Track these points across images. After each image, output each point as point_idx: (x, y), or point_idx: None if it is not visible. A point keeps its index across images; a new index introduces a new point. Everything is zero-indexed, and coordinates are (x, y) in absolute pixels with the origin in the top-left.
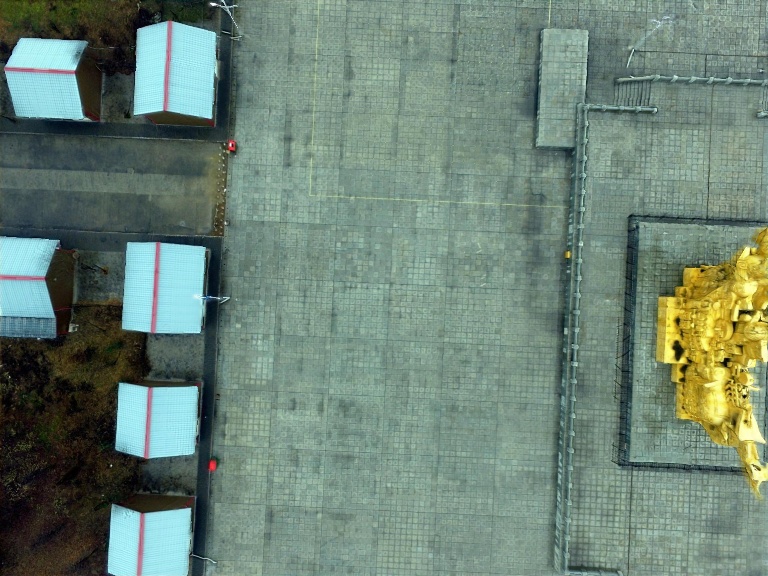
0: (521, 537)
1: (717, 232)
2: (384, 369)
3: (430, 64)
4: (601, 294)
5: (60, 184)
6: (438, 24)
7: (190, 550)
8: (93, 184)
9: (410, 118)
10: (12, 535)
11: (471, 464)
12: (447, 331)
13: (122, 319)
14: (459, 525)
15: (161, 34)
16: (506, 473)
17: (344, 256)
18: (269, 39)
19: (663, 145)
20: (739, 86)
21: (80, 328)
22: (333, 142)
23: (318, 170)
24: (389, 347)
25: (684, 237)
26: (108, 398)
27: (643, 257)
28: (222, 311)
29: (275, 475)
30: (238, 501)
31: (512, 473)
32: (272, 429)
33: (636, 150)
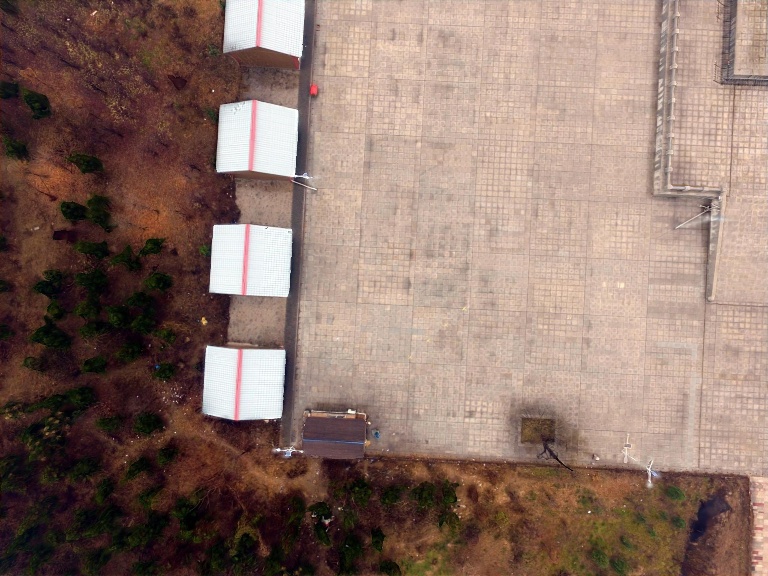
0: (620, 165)
1: None
2: None
3: None
4: None
5: None
6: None
7: None
8: None
9: None
10: (116, 156)
11: (570, 93)
12: None
13: None
14: (558, 154)
15: None
16: (605, 102)
17: None
18: None
19: None
20: None
21: None
22: None
23: None
24: None
25: None
26: (210, 24)
27: None
28: None
29: (374, 105)
30: (338, 130)
31: (611, 102)
32: (372, 59)
33: None
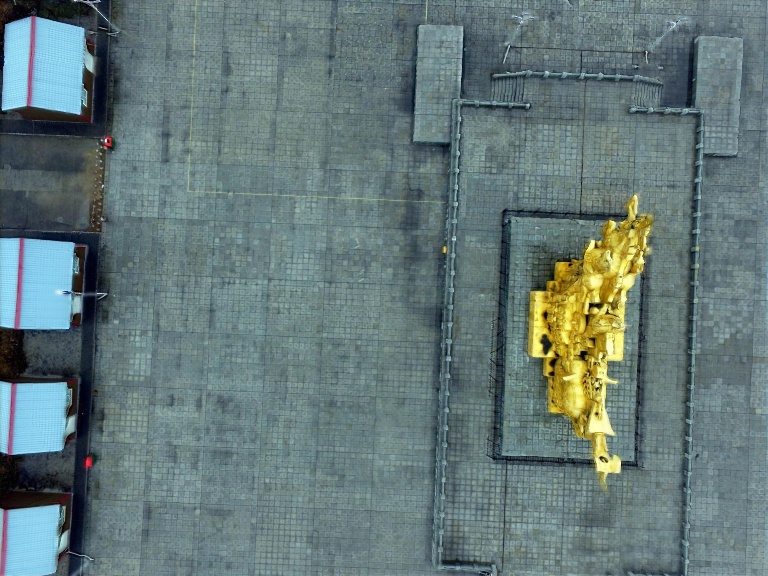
0: (399, 532)
1: (588, 226)
2: (262, 365)
3: (308, 60)
4: (476, 289)
5: None
6: (316, 20)
7: (65, 547)
8: None
9: (288, 114)
10: None
11: (349, 459)
12: (325, 326)
13: None
14: (337, 520)
15: (25, 29)
16: (384, 468)
17: (222, 252)
18: (147, 35)
19: (537, 140)
20: (611, 82)
21: None
22: (211, 138)
23: (196, 166)
24: (267, 343)
25: (555, 232)
26: None
27: (515, 252)
28: (100, 307)
29: (153, 471)
30: (116, 498)
31: (390, 468)
32: (150, 425)
33: (510, 145)
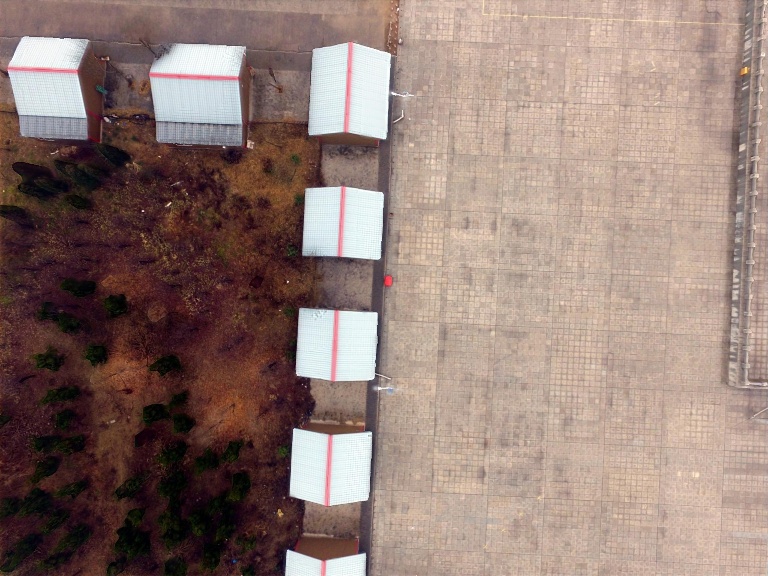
0: (695, 354)
1: None
2: (557, 188)
3: None
4: None
5: (234, 3)
6: None
7: None
8: (267, 3)
9: None
10: (192, 349)
11: (644, 282)
12: (620, 150)
13: (308, 125)
14: (632, 343)
15: None
16: (680, 291)
17: (517, 75)
18: None
19: None
20: None
21: (256, 146)
22: None
23: None
24: (562, 166)
25: None
26: (284, 215)
27: None
28: (395, 130)
29: (448, 293)
30: (412, 319)
31: (686, 291)
32: (445, 248)
33: None
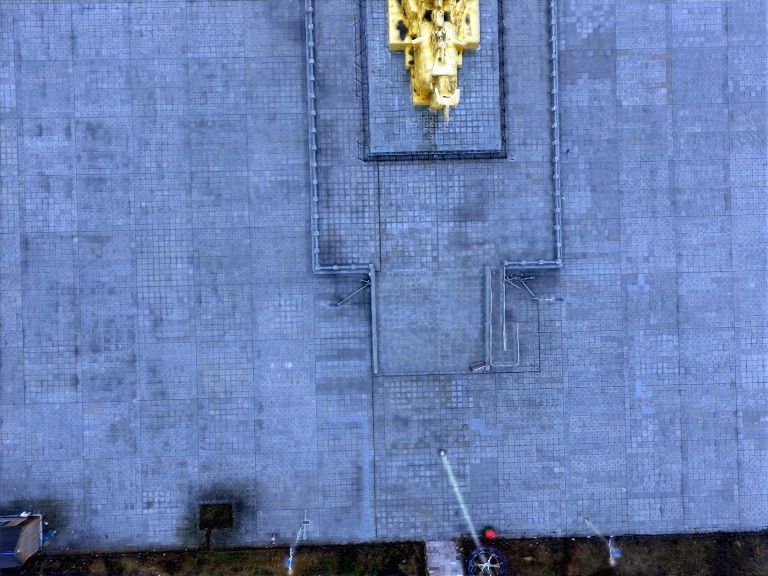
0: (279, 246)
1: None
2: (129, 89)
3: None
4: None
5: None
6: None
7: None
8: None
9: None
10: None
11: (224, 178)
12: (190, 47)
13: None
14: (217, 239)
15: None
16: (260, 184)
17: None
18: None
19: None
20: None
21: None
22: None
23: None
24: (133, 66)
25: None
26: None
27: None
28: None
29: (27, 203)
30: None
31: (266, 184)
32: (20, 157)
33: None
